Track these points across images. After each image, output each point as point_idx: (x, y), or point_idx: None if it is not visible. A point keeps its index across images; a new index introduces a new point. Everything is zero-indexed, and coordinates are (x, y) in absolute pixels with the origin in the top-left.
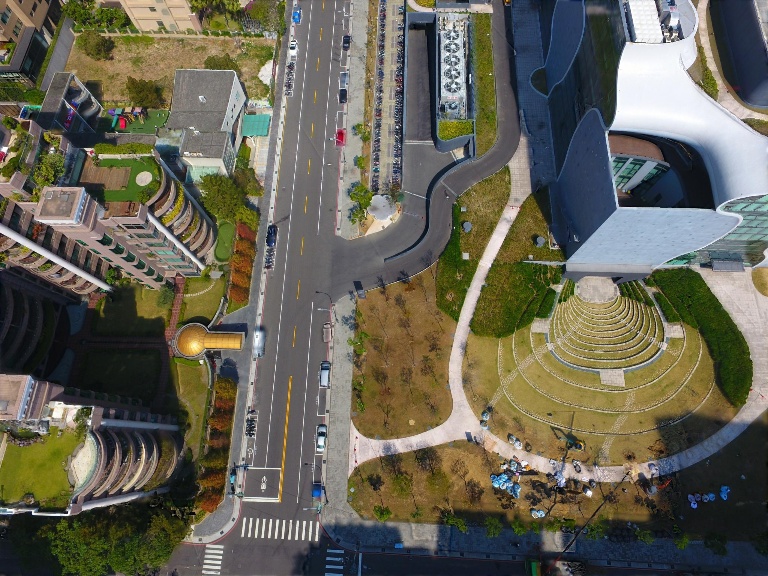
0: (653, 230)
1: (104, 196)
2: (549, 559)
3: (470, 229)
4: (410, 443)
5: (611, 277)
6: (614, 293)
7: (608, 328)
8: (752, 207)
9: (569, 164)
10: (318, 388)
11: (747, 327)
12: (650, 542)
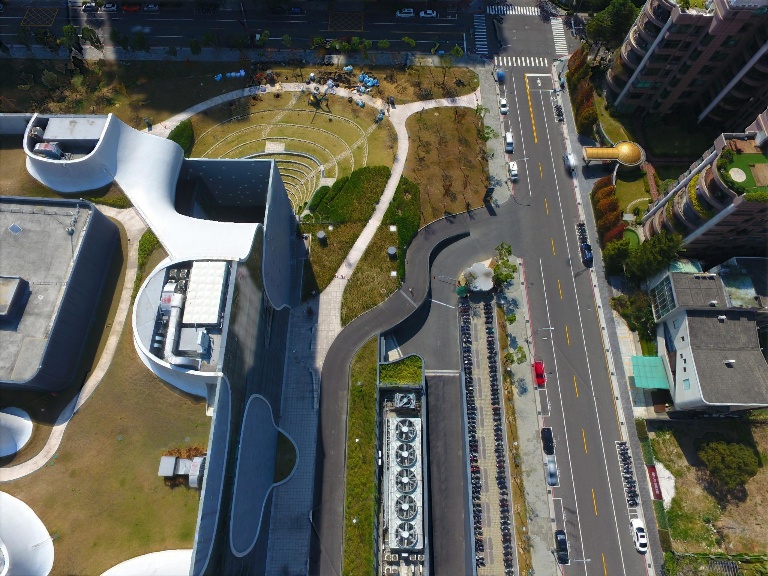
0: None
1: (767, 159)
2: None
3: None
4: (437, 103)
5: None
6: None
7: None
8: None
9: None
10: None
11: None
12: None
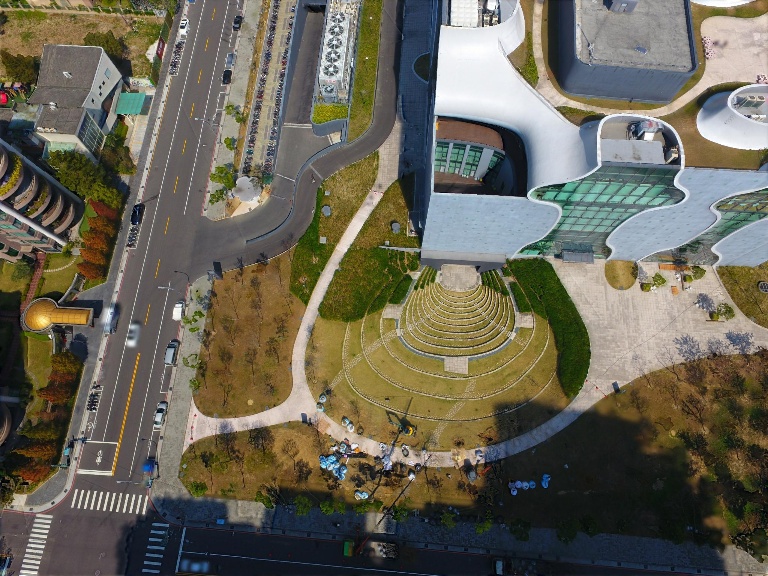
0: (482, 218)
1: None
2: (366, 540)
3: (329, 213)
4: (246, 422)
5: (474, 266)
6: (476, 282)
7: (463, 316)
8: (564, 196)
9: (427, 150)
10: (164, 366)
11: (592, 319)
12: (452, 525)
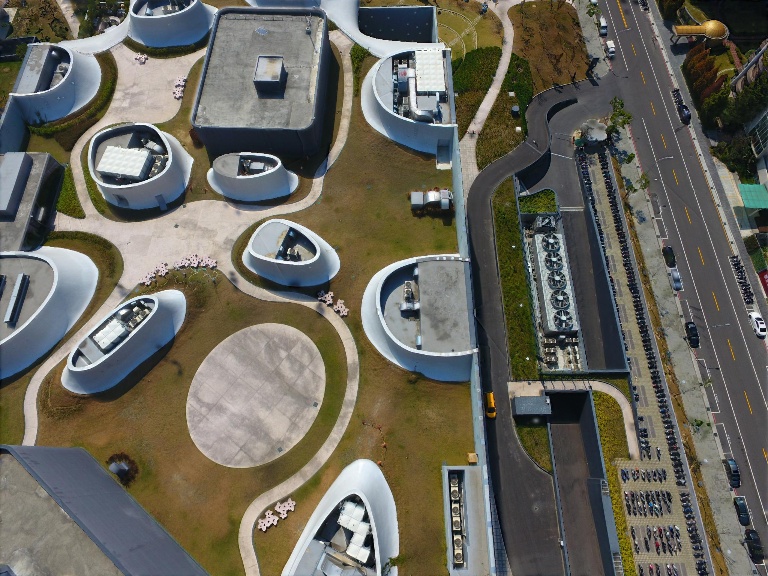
0: None
1: None
2: None
3: None
4: None
5: None
6: None
7: None
8: None
9: None
10: None
11: None
12: None
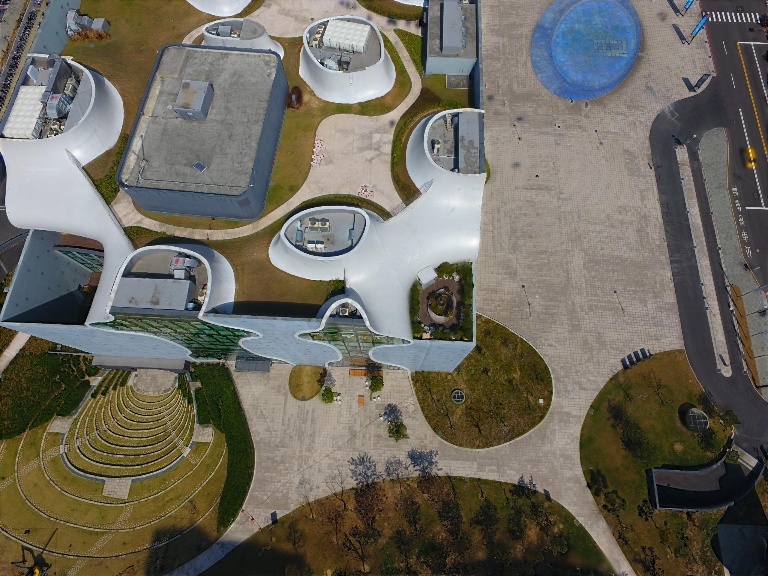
0: None
1: None
2: None
3: None
4: None
5: None
6: (172, 384)
7: (147, 426)
8: None
9: None
10: None
11: (263, 436)
12: None
